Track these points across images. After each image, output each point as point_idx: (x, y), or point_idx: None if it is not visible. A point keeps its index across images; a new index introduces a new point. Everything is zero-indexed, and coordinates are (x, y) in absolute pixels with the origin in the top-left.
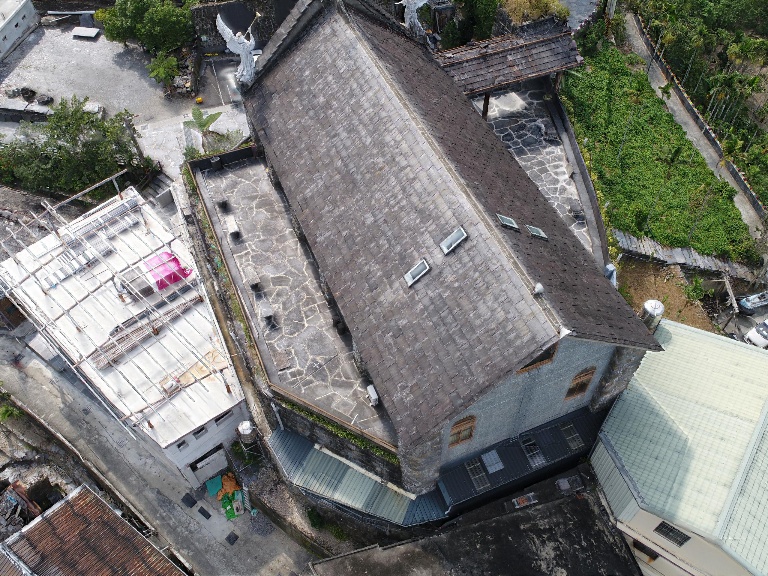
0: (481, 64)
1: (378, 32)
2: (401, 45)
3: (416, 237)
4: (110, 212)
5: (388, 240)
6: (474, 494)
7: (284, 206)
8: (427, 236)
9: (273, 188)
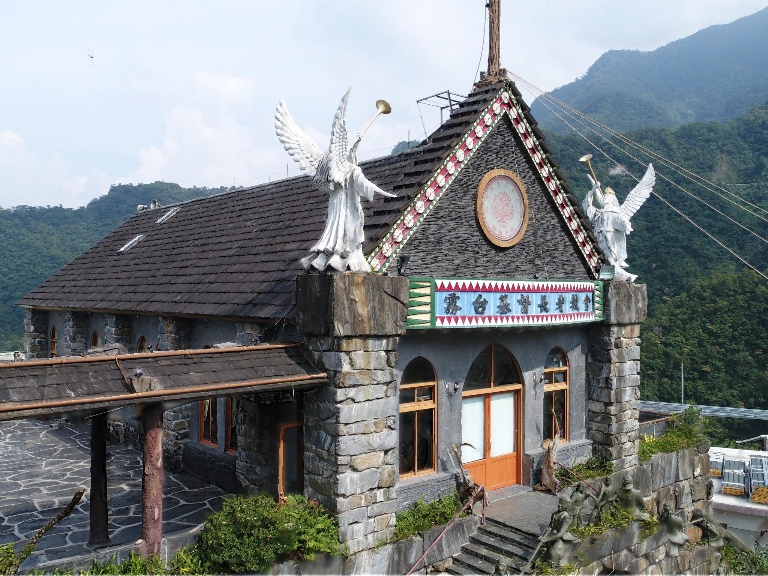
0: None
1: (384, 189)
2: None
3: None
4: (763, 474)
5: None
6: None
7: None
8: None
9: None
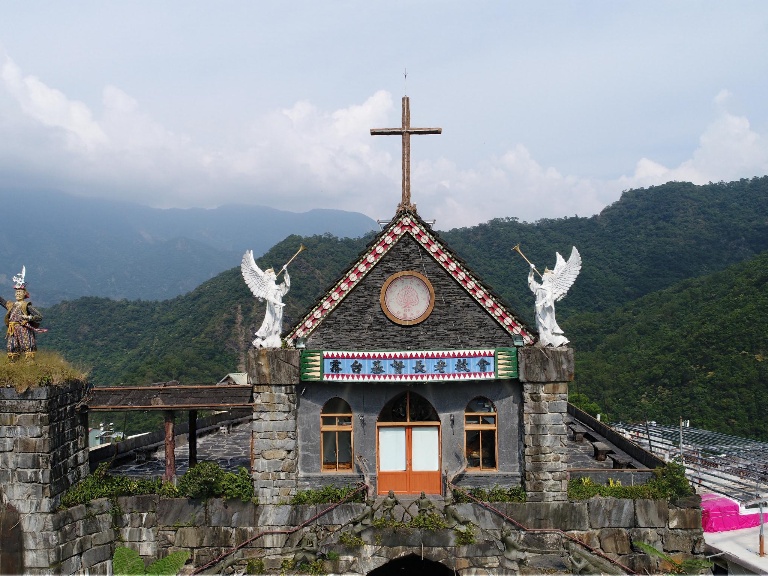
0: None
1: None
2: None
3: None
4: None
5: None
6: None
7: None
8: None
9: None
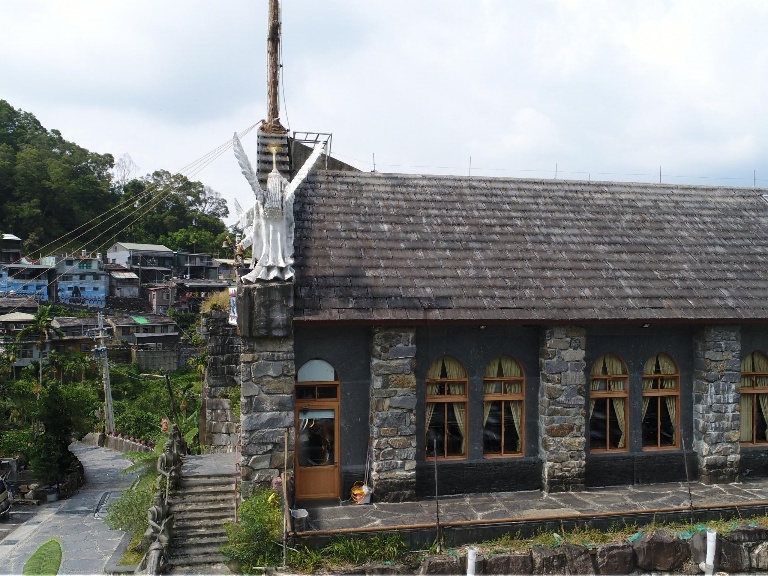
0: None
1: None
2: None
3: (762, 225)
4: None
5: (759, 243)
6: None
7: (473, 497)
8: (763, 219)
9: (412, 502)
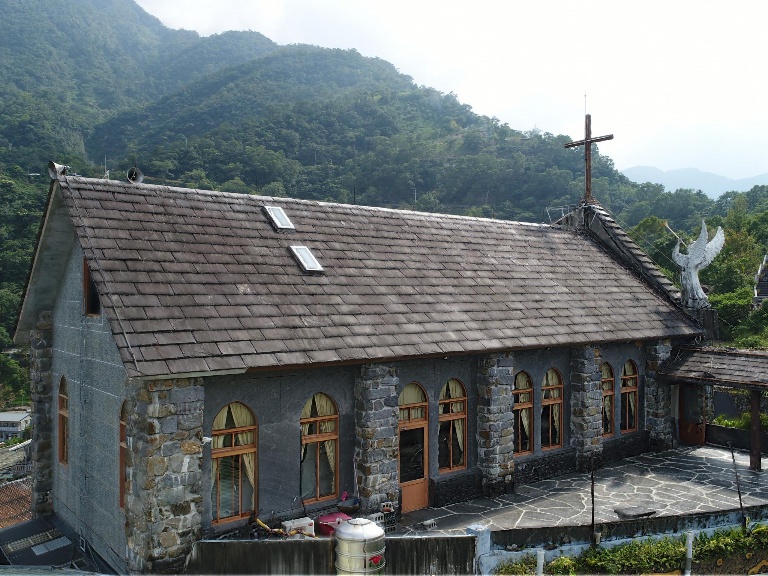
0: (766, 364)
1: (595, 255)
2: (618, 277)
3: None
4: None
5: None
6: (2, 542)
7: None
8: None
9: None
